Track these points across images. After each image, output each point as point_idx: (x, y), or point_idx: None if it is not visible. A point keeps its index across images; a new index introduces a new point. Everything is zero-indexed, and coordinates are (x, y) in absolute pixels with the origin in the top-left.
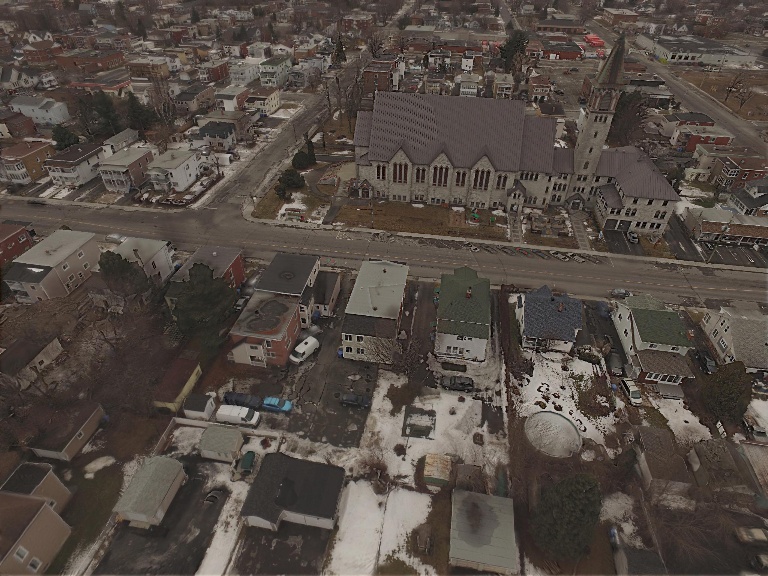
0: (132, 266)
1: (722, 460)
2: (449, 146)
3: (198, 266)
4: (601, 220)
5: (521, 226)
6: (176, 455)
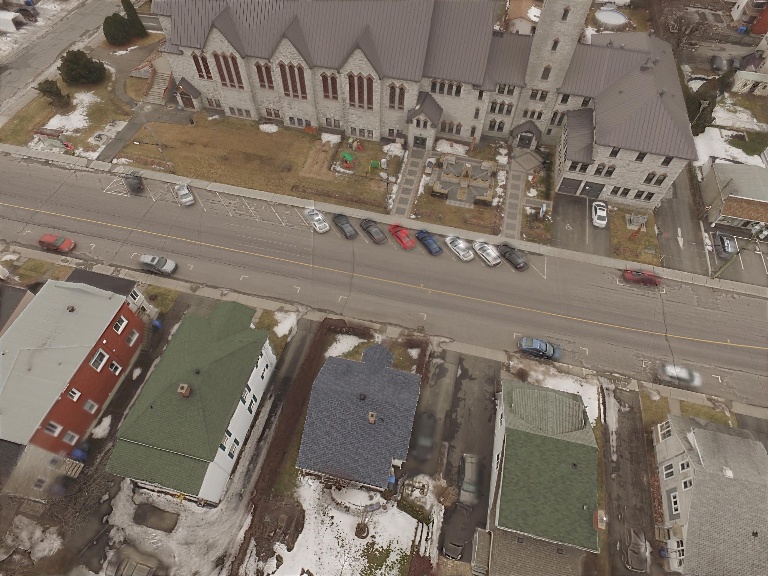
0: None
1: None
2: (304, 24)
3: None
4: (556, 176)
5: (420, 180)
6: None
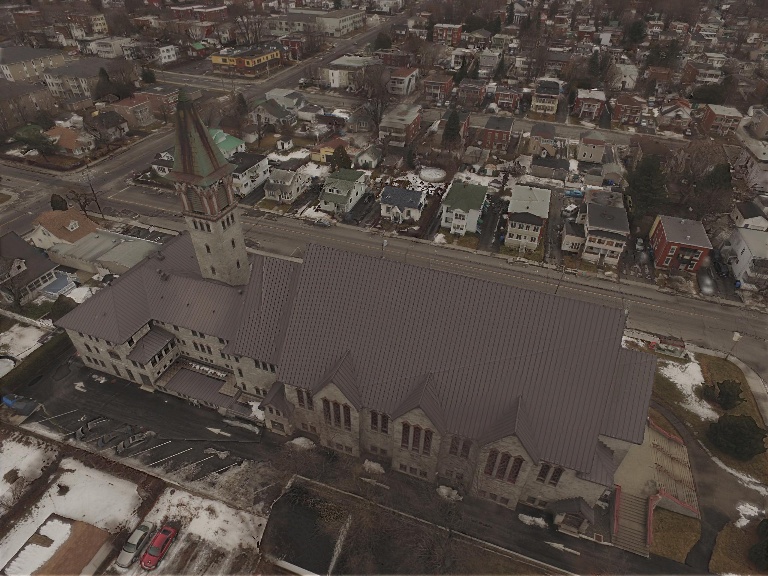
0: (710, 176)
1: None
2: None
3: (654, 155)
4: None
5: None
6: (612, 186)
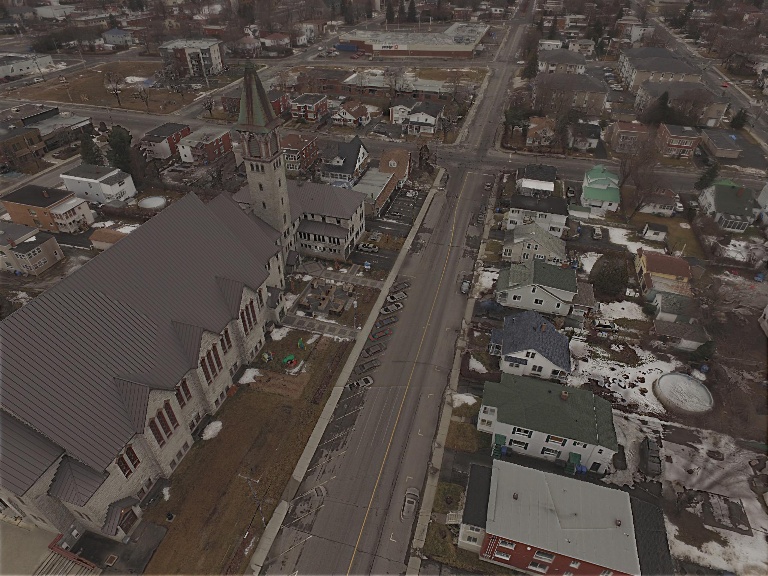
0: None
1: (680, 302)
2: (183, 319)
3: None
4: (337, 255)
5: (321, 321)
6: None
